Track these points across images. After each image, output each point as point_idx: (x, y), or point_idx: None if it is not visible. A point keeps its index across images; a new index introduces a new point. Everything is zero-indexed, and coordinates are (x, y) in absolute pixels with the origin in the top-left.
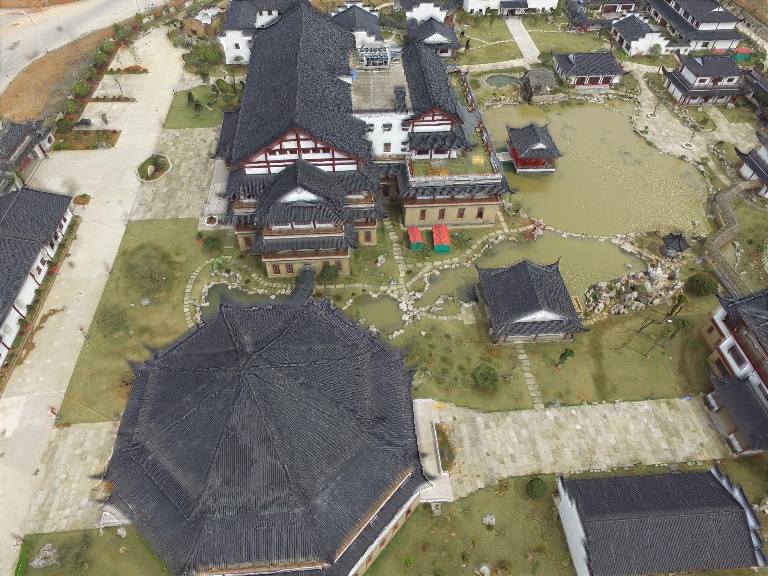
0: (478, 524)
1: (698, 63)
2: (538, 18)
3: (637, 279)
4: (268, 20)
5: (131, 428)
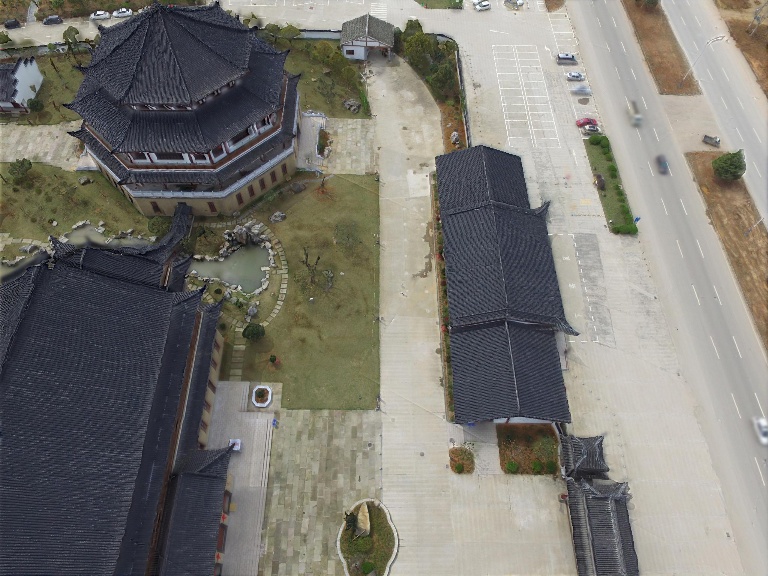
0: None
1: None
2: None
3: None
4: None
5: (272, 76)
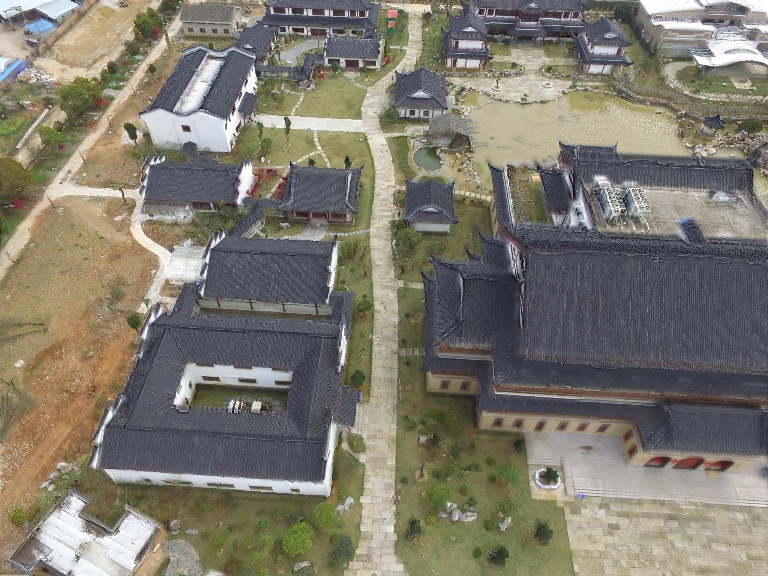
0: None
1: (470, 32)
2: (284, 97)
3: None
4: (183, 400)
5: None
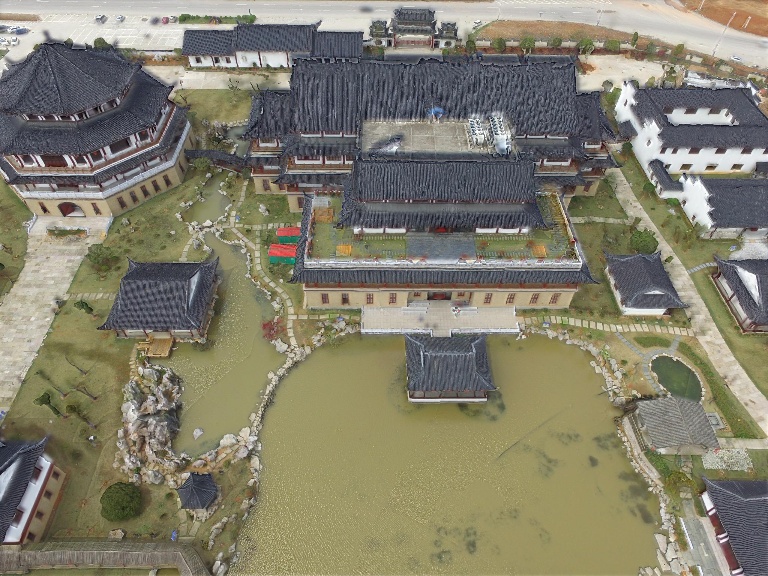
0: (3, 242)
1: None
2: None
3: None
4: None
5: None
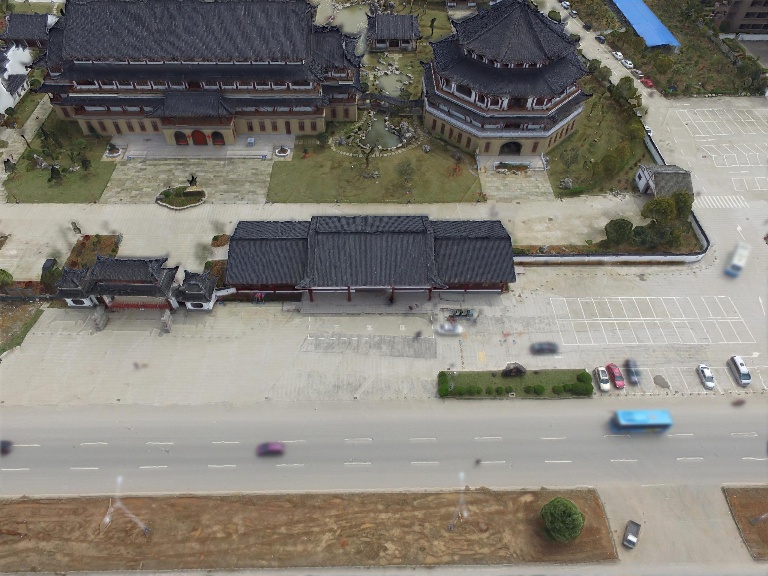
0: None
1: None
2: None
3: (381, 0)
4: None
5: (525, 92)
